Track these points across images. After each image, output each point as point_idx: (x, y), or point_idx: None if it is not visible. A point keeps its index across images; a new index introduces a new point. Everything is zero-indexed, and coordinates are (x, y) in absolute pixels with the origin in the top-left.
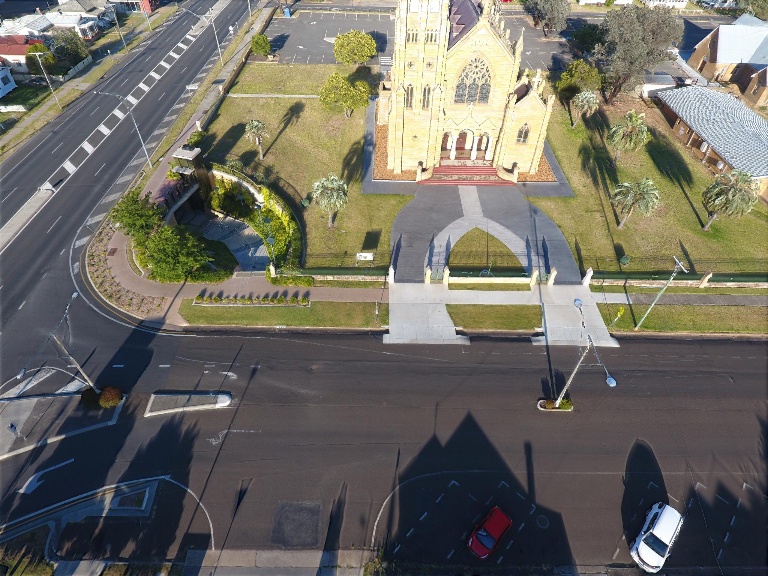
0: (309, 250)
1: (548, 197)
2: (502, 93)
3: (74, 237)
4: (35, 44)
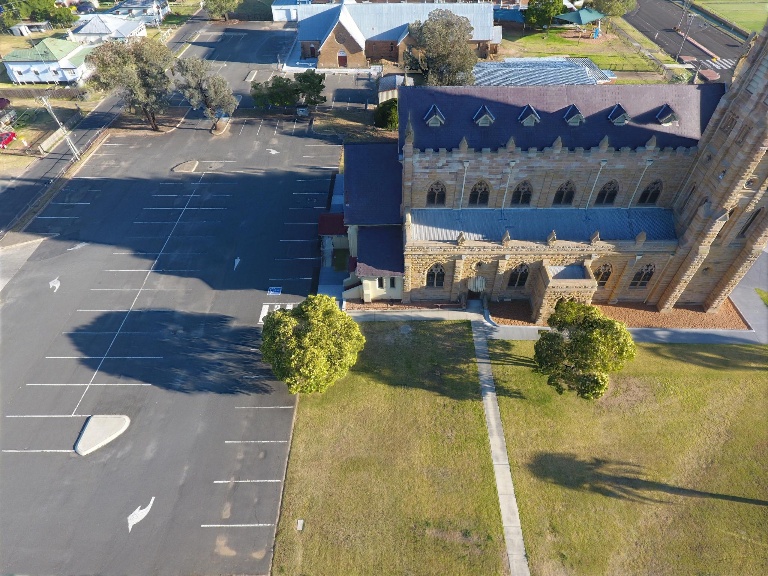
0: None
1: None
2: None
3: None
4: None
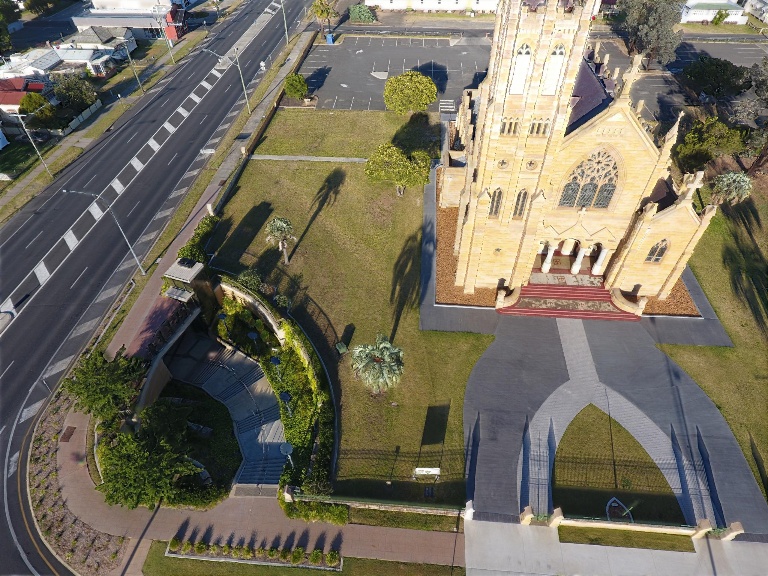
0: (344, 442)
1: (692, 346)
2: (632, 197)
3: (22, 402)
4: (30, 93)
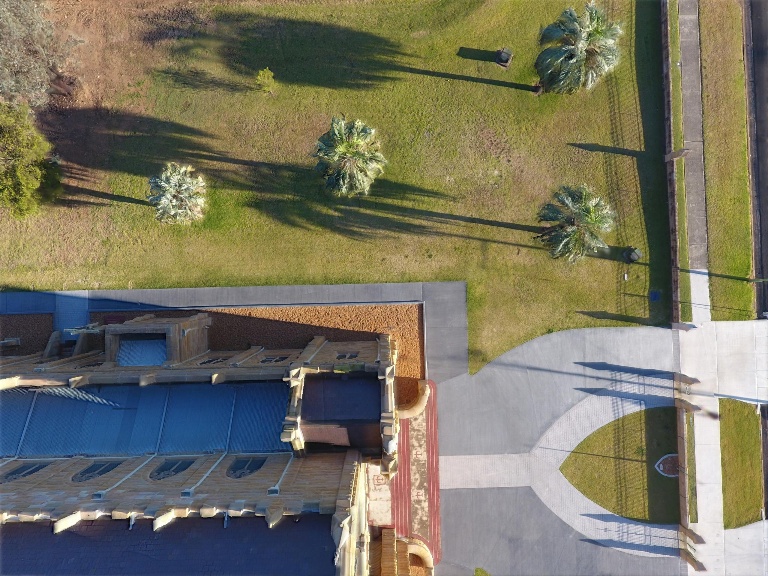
0: None
1: (469, 331)
2: None
3: None
4: None
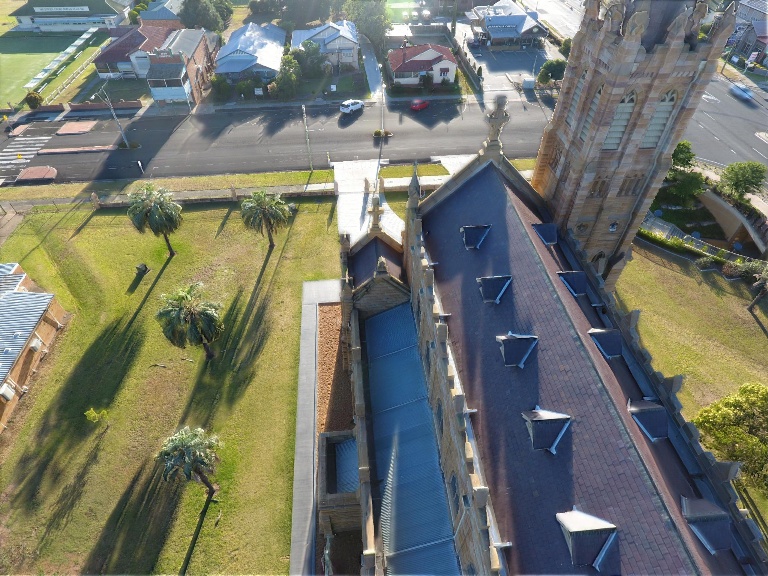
0: None
1: None
2: None
3: None
4: None
